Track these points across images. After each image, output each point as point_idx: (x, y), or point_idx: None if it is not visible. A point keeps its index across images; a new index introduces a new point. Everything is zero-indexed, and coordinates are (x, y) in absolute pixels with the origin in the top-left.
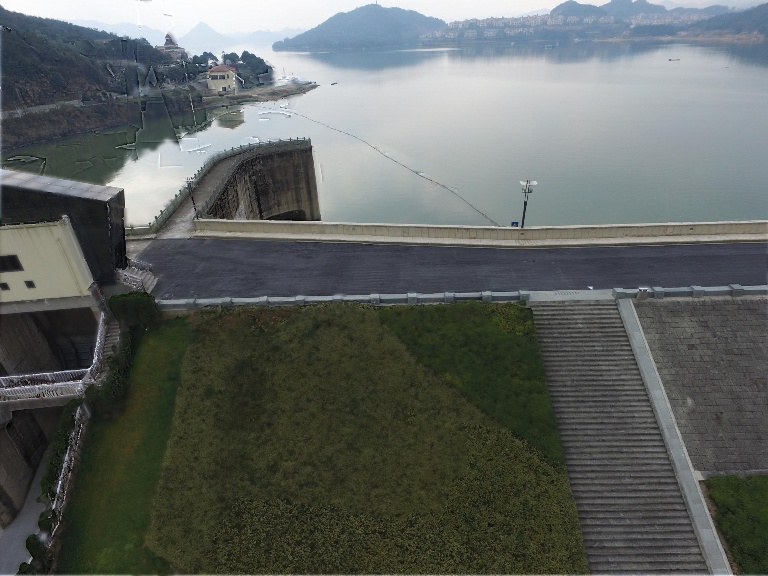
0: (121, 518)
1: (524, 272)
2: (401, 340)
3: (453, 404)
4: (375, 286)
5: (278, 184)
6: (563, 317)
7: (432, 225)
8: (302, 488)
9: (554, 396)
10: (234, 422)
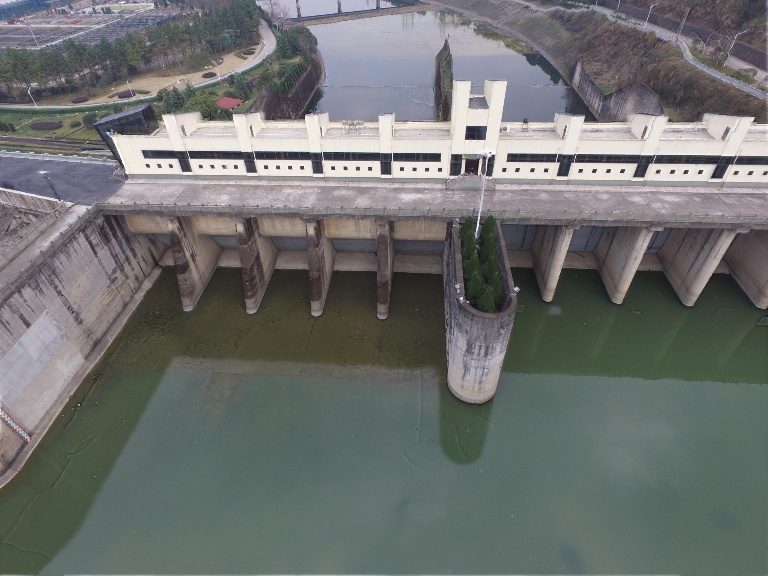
0: None
1: None
2: None
3: None
4: None
5: None
6: None
7: None
8: None
9: None
10: None
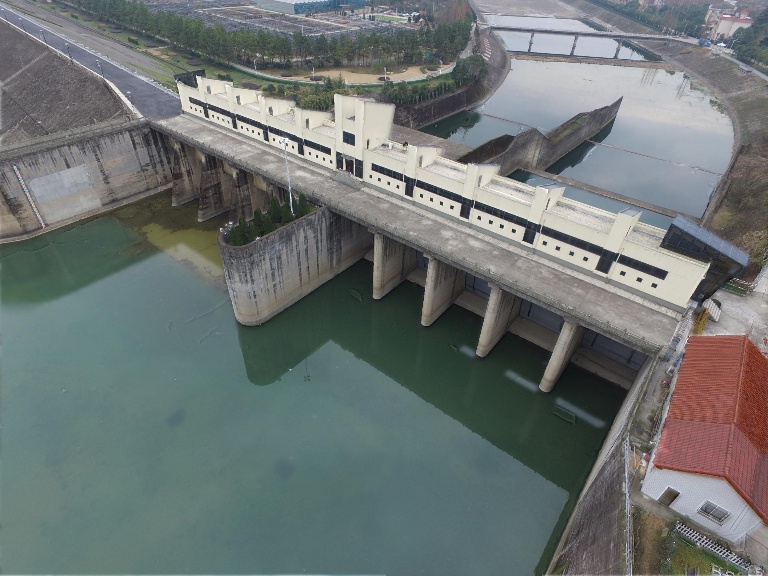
0: None
1: None
2: None
3: None
4: None
5: None
6: None
7: None
8: None
9: None
10: None
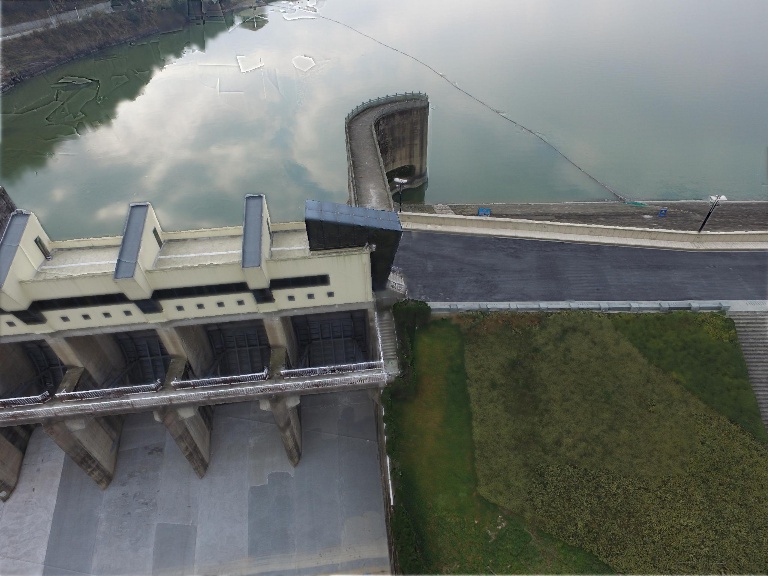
0: (447, 474)
1: (711, 279)
2: (634, 344)
3: (682, 397)
4: (593, 292)
5: (395, 141)
6: (756, 325)
7: (619, 227)
8: (582, 458)
9: (754, 390)
10: (520, 408)
